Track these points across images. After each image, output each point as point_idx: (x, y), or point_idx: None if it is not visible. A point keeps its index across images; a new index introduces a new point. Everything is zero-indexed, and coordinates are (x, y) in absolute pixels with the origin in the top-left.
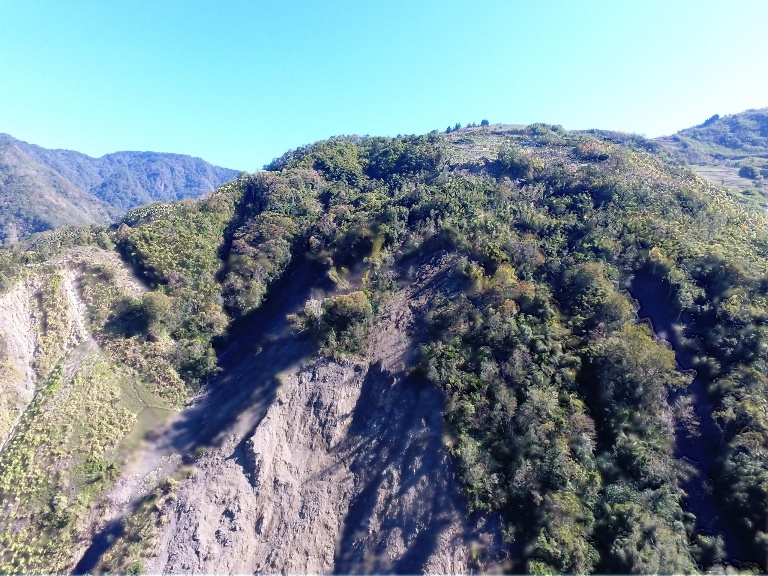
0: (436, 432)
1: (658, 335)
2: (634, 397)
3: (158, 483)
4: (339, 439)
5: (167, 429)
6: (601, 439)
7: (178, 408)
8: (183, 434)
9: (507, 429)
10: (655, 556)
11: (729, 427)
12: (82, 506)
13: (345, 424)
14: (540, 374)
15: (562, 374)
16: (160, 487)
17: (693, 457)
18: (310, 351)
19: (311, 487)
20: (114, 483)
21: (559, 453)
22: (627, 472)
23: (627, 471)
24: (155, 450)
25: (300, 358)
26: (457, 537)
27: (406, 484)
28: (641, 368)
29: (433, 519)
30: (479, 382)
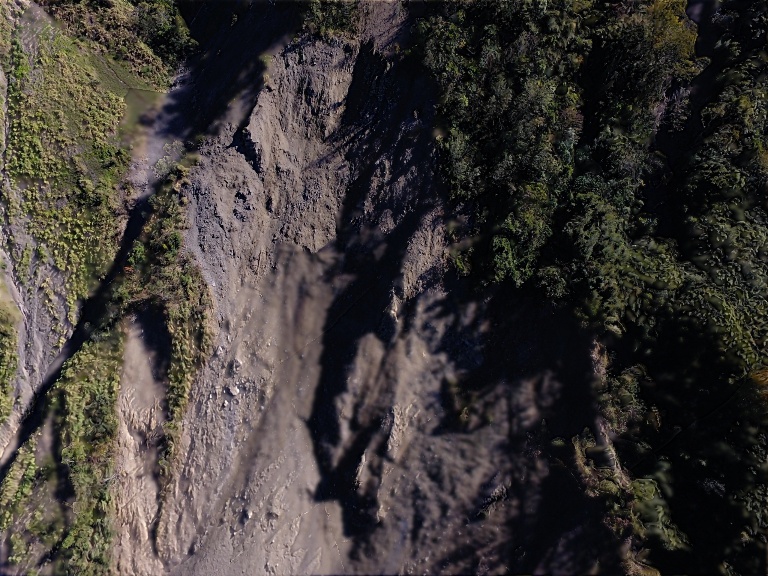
0: (428, 125)
1: (691, 8)
2: (633, 89)
3: (169, 169)
4: (333, 129)
5: (159, 113)
6: (586, 133)
7: (163, 89)
8: (177, 118)
9: (497, 122)
10: (596, 235)
11: (713, 123)
12: (108, 188)
13: (338, 113)
14: (543, 62)
15: (567, 61)
16: (172, 173)
17: (666, 150)
18: (293, 25)
19: (311, 174)
20: (128, 167)
21: (541, 150)
22: (599, 164)
23: (600, 163)
24: (155, 135)
25: (283, 34)
26: (438, 218)
27: (397, 173)
28: (653, 55)
29: (419, 203)
30: (477, 71)
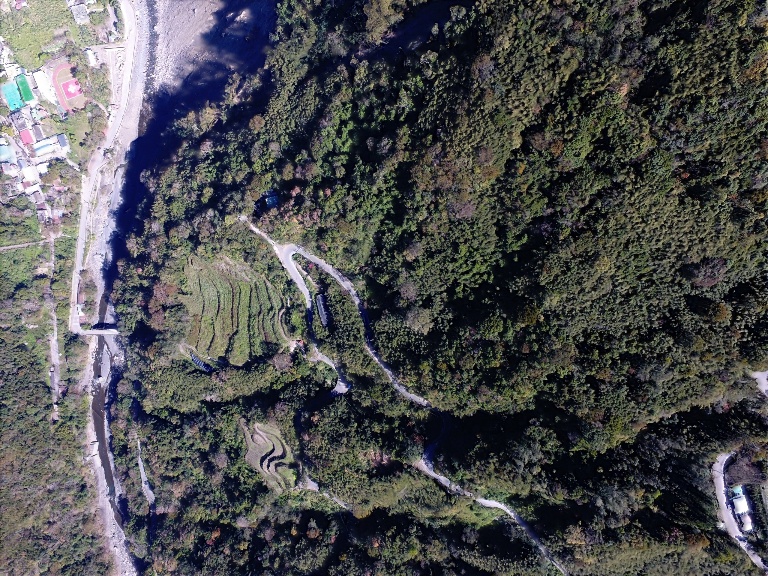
0: None
1: (428, 25)
2: (364, 18)
3: None
4: None
5: None
6: None
7: None
8: None
9: None
10: None
11: None
12: None
13: None
14: None
15: None
16: None
17: None
18: None
19: None
20: None
21: None
22: None
23: None
24: None
25: None
26: None
27: None
28: None
29: None
30: None
